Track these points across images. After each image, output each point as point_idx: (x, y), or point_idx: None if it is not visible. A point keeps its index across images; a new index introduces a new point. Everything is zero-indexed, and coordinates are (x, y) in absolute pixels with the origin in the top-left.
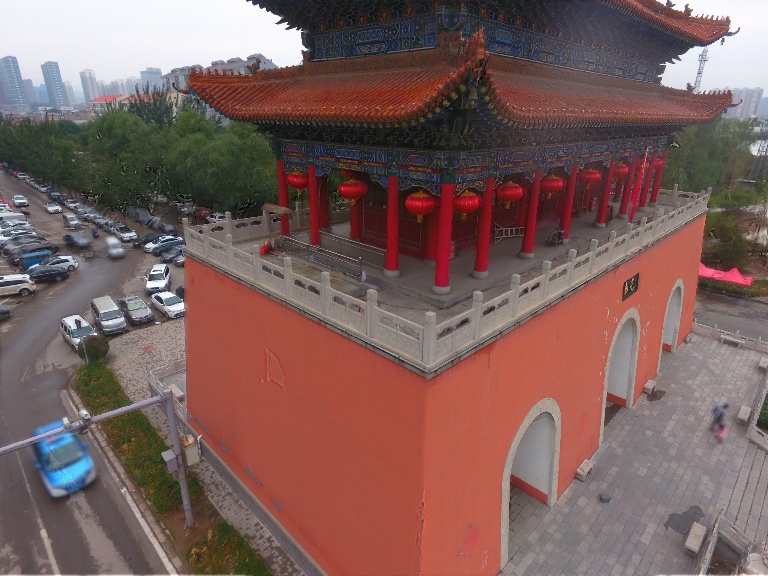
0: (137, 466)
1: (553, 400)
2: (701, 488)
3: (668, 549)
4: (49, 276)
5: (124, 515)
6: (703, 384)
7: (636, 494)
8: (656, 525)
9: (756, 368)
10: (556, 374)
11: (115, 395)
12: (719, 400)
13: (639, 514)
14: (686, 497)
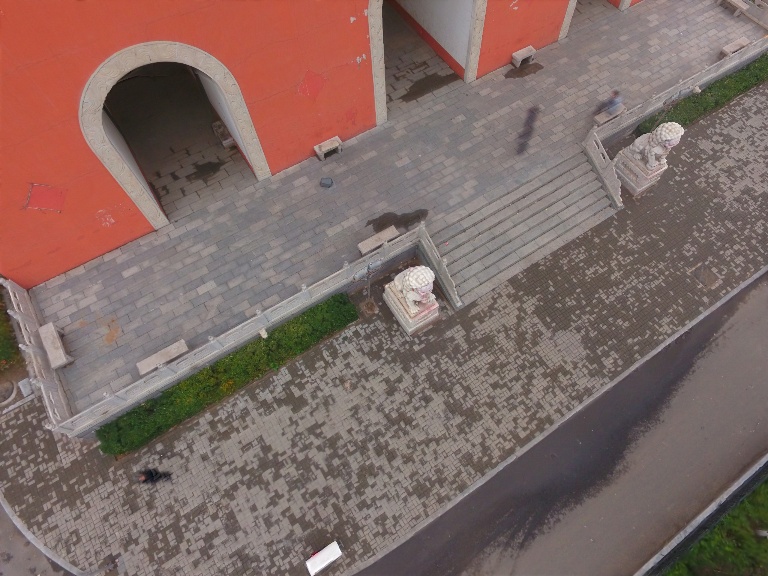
0: None
1: (190, 46)
2: (453, 193)
3: (347, 245)
4: None
5: None
6: (609, 64)
7: (369, 185)
8: (358, 220)
9: (719, 52)
10: (180, 4)
11: None
12: (605, 91)
13: (351, 206)
14: (424, 199)
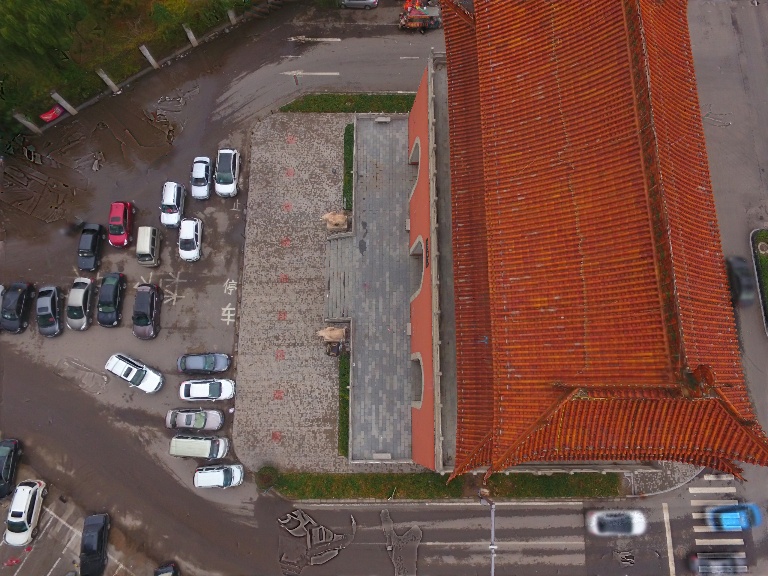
0: (418, 494)
1: None
2: None
3: None
4: (14, 462)
5: (445, 510)
6: None
7: None
8: None
9: None
10: None
11: (336, 481)
12: None
13: None
14: None
